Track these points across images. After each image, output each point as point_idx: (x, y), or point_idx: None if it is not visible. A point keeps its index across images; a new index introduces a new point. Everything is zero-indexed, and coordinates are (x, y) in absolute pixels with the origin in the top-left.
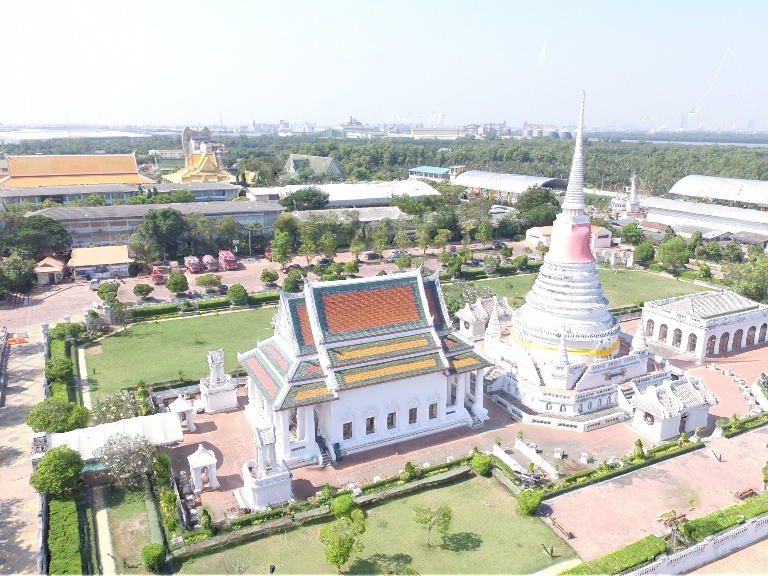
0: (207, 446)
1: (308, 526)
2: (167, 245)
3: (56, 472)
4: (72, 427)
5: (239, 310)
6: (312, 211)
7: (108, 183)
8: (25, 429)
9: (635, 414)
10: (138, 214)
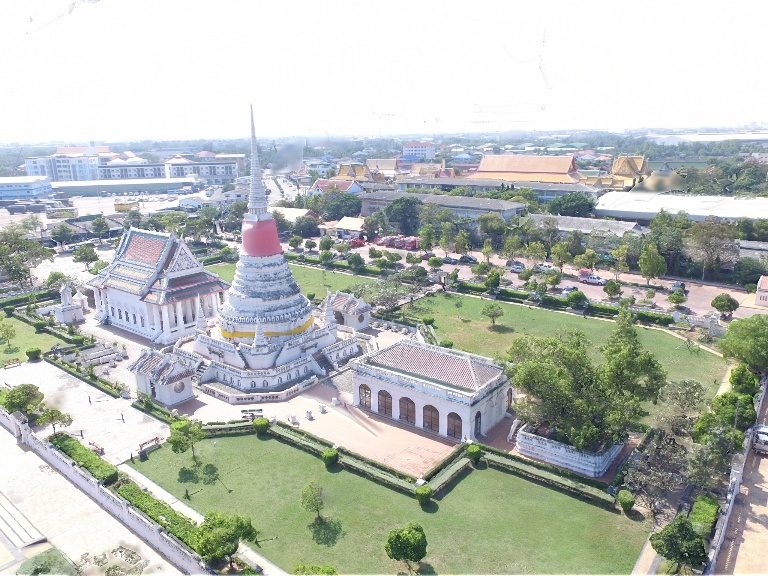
0: None
1: None
2: (403, 225)
3: None
4: None
5: (319, 268)
6: (542, 215)
7: (491, 179)
8: None
9: None
10: None
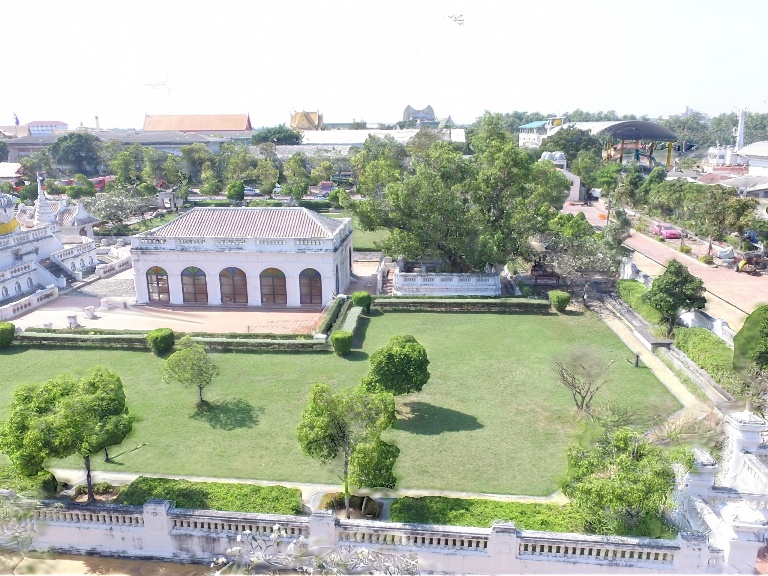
0: None
1: None
2: (78, 168)
3: None
4: None
5: None
6: (251, 147)
7: None
8: None
9: None
10: None
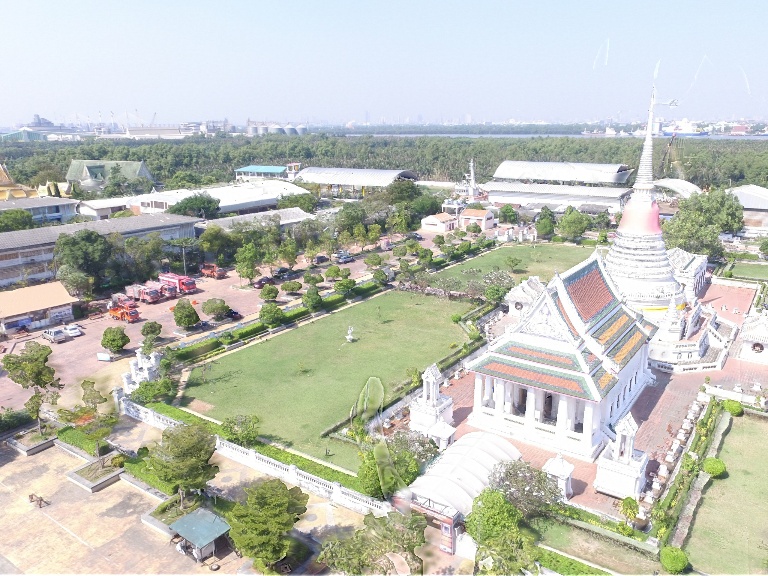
0: None
1: (706, 493)
2: (92, 276)
3: (511, 517)
4: (412, 477)
5: (280, 332)
6: (221, 219)
7: None
8: None
9: (743, 347)
10: (35, 242)
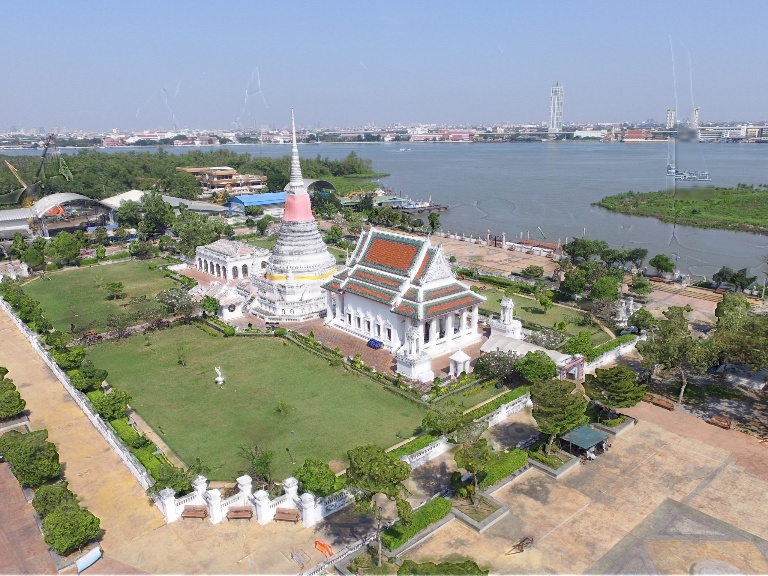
0: (475, 363)
1: None
2: None
3: None
4: None
5: (137, 421)
6: None
7: None
8: (530, 417)
9: None
10: None
